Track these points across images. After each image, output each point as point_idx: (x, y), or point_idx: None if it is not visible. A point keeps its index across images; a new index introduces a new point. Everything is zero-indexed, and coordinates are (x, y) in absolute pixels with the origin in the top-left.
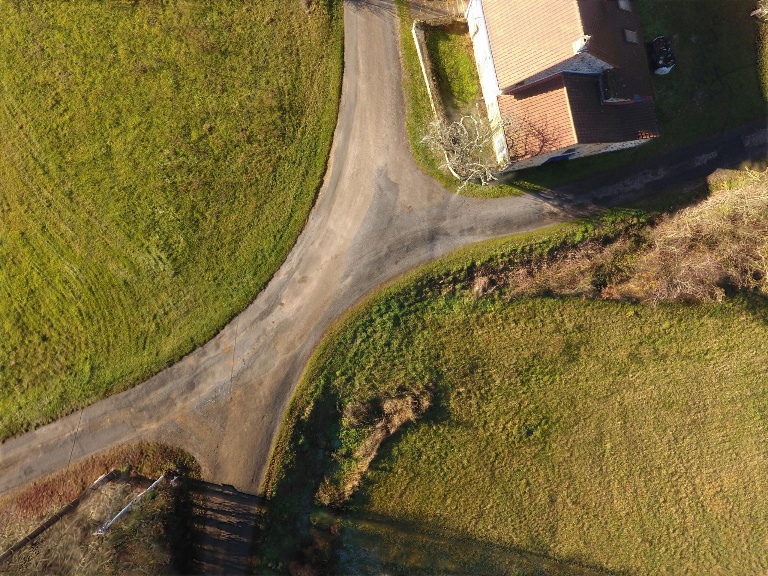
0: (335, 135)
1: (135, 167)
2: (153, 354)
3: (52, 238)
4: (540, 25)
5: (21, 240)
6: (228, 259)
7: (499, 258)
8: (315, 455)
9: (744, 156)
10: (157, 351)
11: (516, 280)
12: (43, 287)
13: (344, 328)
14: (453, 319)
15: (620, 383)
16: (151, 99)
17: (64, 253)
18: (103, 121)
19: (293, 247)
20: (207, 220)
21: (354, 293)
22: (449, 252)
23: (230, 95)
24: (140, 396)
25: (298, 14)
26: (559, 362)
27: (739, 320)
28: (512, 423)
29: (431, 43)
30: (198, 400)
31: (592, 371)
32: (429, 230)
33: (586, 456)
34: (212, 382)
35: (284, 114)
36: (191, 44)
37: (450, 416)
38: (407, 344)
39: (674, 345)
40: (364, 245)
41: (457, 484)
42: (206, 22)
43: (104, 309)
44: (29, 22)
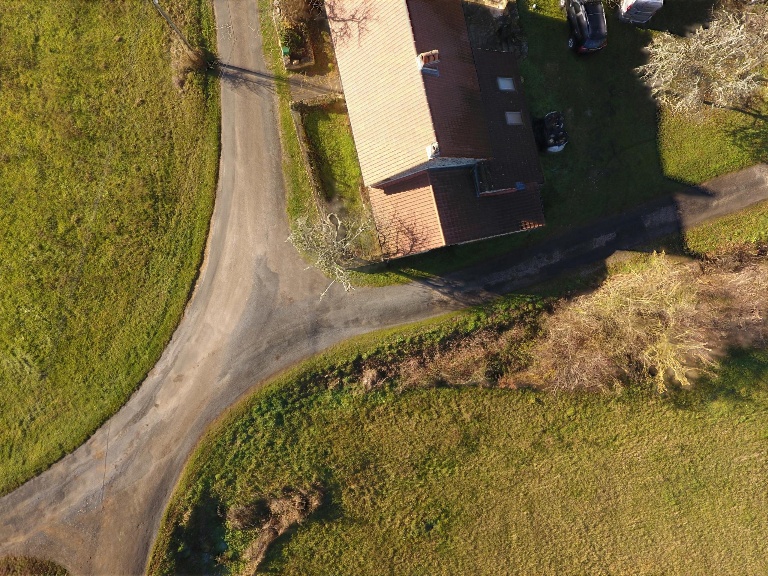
0: (212, 223)
1: None
2: (19, 463)
3: None
4: (396, 124)
5: None
6: (99, 359)
7: (387, 350)
8: (199, 560)
9: (645, 236)
10: (23, 460)
11: (408, 371)
12: None
13: (222, 429)
14: (341, 414)
15: (524, 472)
16: (15, 190)
17: None
18: None
19: (168, 344)
20: (76, 318)
21: (232, 392)
22: (333, 345)
23: (99, 183)
24: (5, 508)
25: (171, 94)
26: (457, 454)
27: (648, 404)
28: (409, 518)
29: (310, 123)
30: (68, 510)
31: (493, 461)
32: (311, 322)
33: (491, 548)
34: (83, 491)
35: (157, 202)
36: (57, 130)
37: (343, 513)
38: (291, 443)
39: (580, 432)
40: (242, 340)
41: None
42: (73, 106)
43: None
44: None
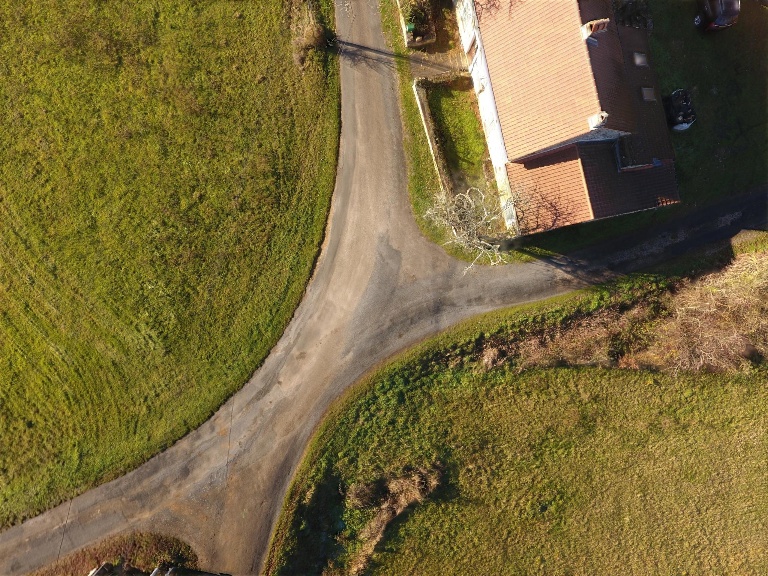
0: (333, 200)
1: (122, 240)
2: (144, 439)
3: (36, 318)
4: (552, 95)
5: (3, 321)
6: (222, 335)
7: (509, 329)
8: (317, 538)
9: None
10: (149, 436)
11: (527, 350)
12: (27, 370)
13: (346, 407)
14: (461, 393)
15: (639, 454)
16: (137, 166)
17: (49, 333)
18: (87, 191)
19: (290, 321)
20: (199, 294)
21: (356, 369)
22: (456, 323)
23: (221, 160)
24: (132, 484)
25: (291, 71)
26: (574, 434)
27: (766, 386)
28: (525, 499)
29: (433, 100)
30: (193, 487)
31: (609, 443)
32: (434, 300)
33: (603, 530)
34: (207, 467)
35: (278, 179)
36: (179, 106)
37: (459, 493)
38: (413, 421)
39: (696, 414)
40: (365, 318)
41: (468, 563)
42: (194, 82)
43: (92, 392)
44: (7, 87)
